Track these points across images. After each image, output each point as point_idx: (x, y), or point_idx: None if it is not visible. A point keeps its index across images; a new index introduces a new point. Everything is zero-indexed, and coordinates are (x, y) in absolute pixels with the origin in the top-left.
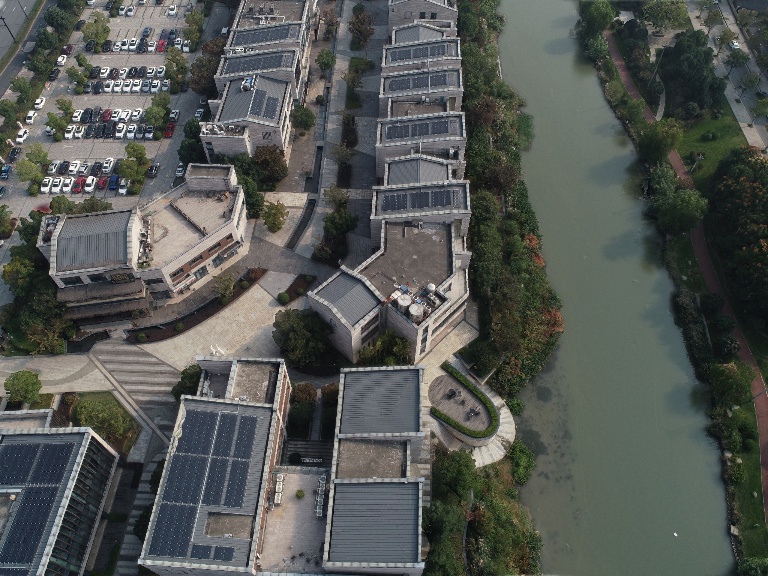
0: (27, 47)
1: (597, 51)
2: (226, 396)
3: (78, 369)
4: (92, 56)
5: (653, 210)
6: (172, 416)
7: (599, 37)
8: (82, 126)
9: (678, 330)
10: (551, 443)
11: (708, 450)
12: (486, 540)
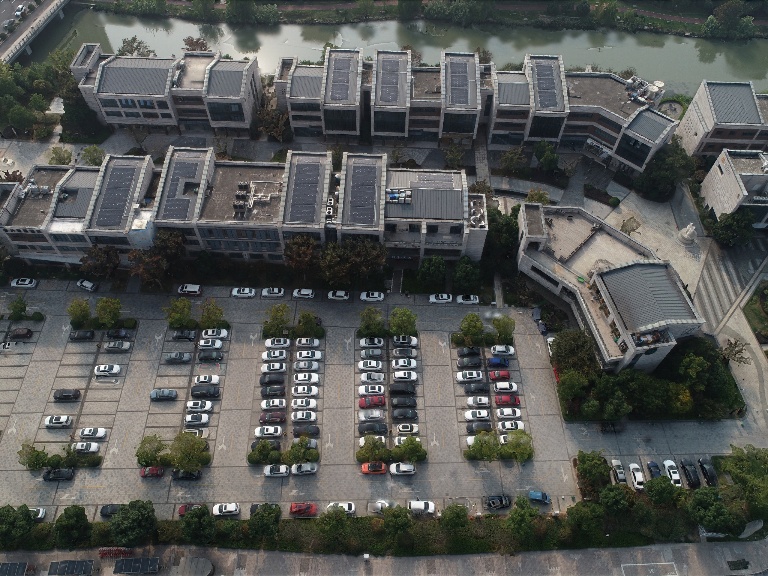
0: (196, 571)
1: (275, 14)
2: (767, 175)
3: (733, 339)
4: (216, 467)
5: (468, 19)
6: (744, 262)
7: (261, 7)
8: (398, 427)
9: (565, 31)
10: (665, 88)
11: (644, 35)
12: None
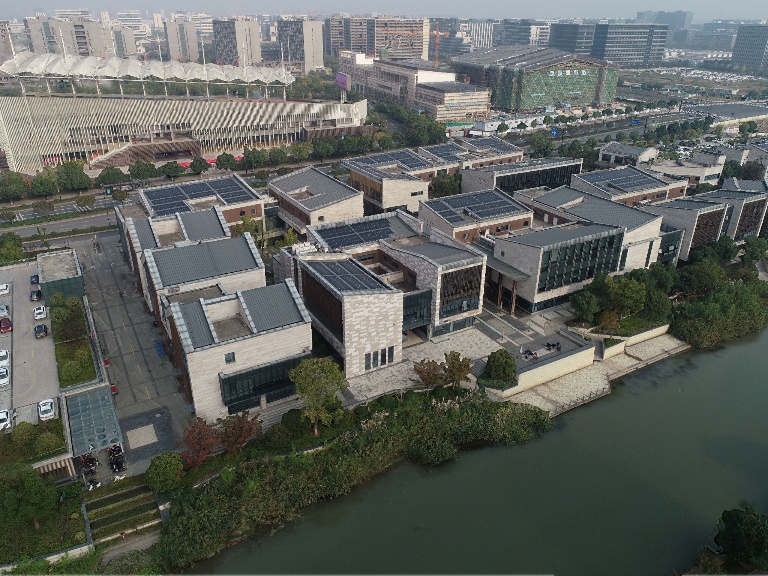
0: None
1: None
2: None
3: None
4: (680, 146)
5: None
6: None
7: None
8: None
9: None
10: None
11: None
12: (744, 284)
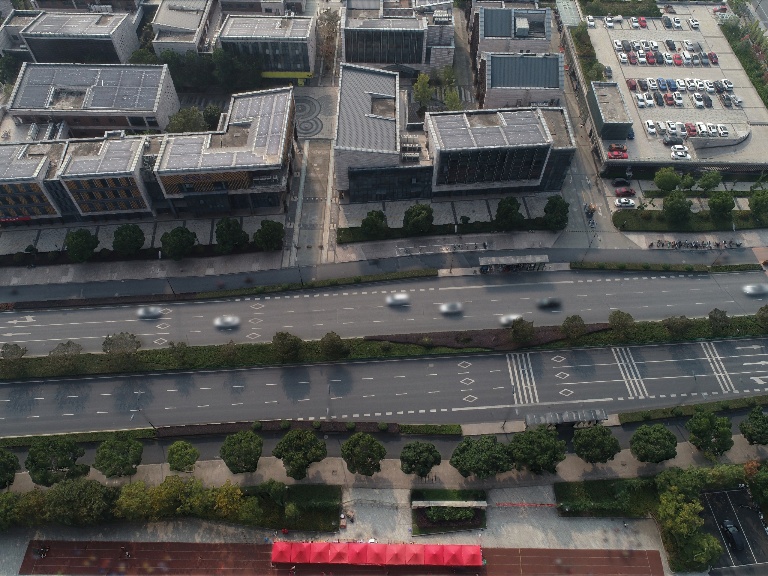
0: None
1: None
2: None
3: None
4: None
5: None
6: None
7: None
8: None
9: None
10: None
11: None
12: None
